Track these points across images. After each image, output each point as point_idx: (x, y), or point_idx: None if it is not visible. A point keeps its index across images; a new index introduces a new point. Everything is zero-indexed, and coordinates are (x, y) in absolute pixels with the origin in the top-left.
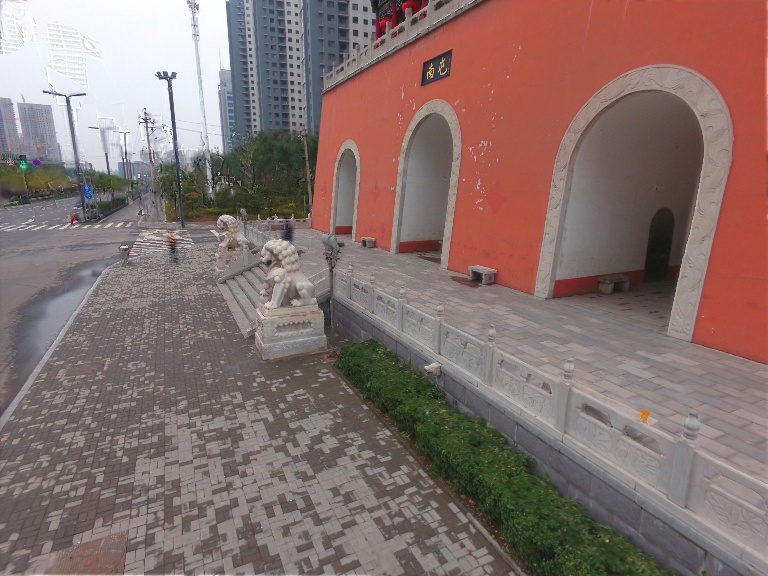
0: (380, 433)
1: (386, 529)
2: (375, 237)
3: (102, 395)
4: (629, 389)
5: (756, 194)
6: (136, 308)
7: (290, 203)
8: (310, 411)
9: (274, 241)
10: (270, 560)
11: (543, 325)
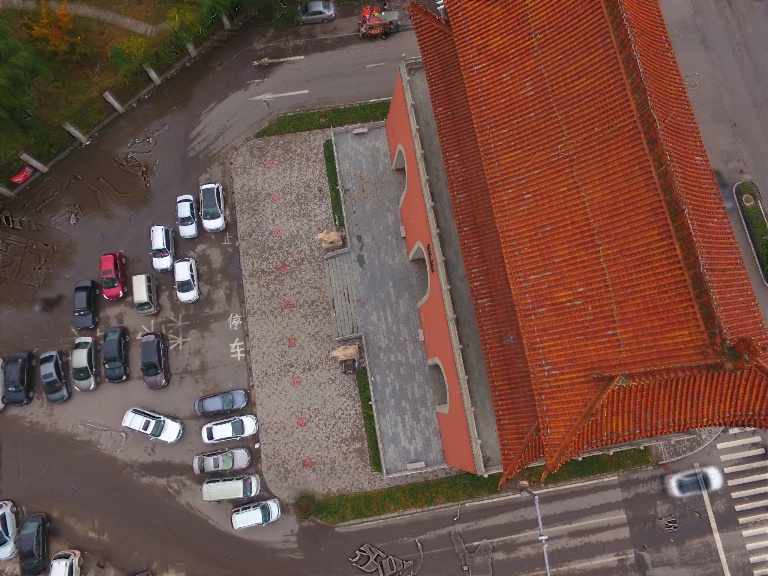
0: None
1: None
2: None
3: None
4: None
5: None
6: None
7: None
8: None
9: None
10: None
11: None
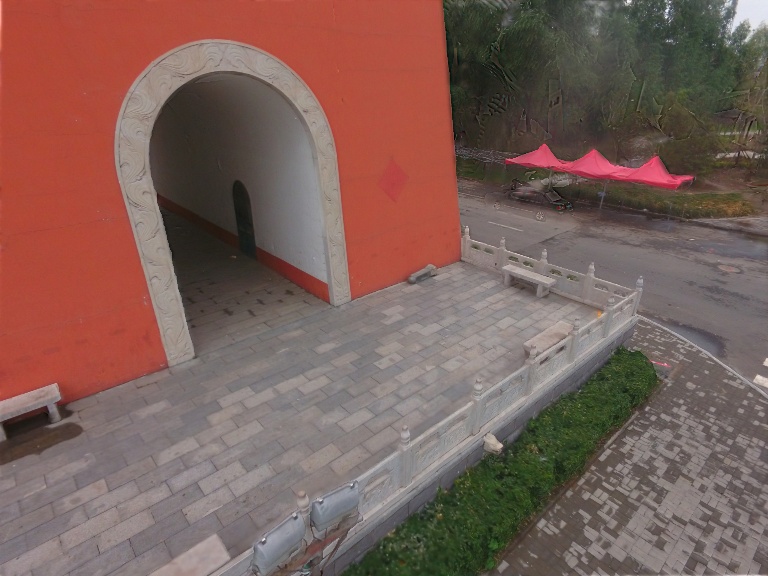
0: (549, 530)
1: (660, 493)
2: None
3: None
4: (469, 336)
5: (357, 178)
6: None
7: None
8: None
9: None
10: (764, 561)
11: (321, 364)
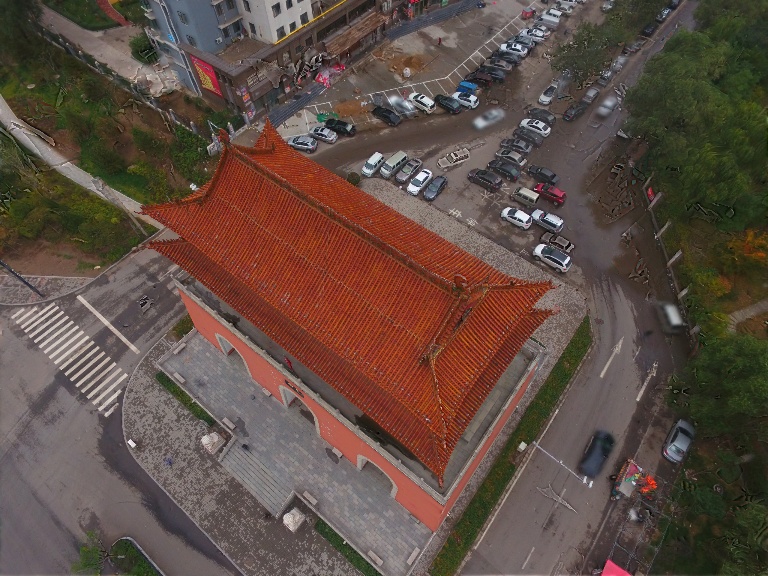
0: (338, 554)
1: None
2: (271, 392)
3: (269, 570)
4: (381, 536)
5: None
6: (215, 510)
7: (75, 159)
8: (320, 553)
9: (288, 521)
10: None
11: (363, 501)
